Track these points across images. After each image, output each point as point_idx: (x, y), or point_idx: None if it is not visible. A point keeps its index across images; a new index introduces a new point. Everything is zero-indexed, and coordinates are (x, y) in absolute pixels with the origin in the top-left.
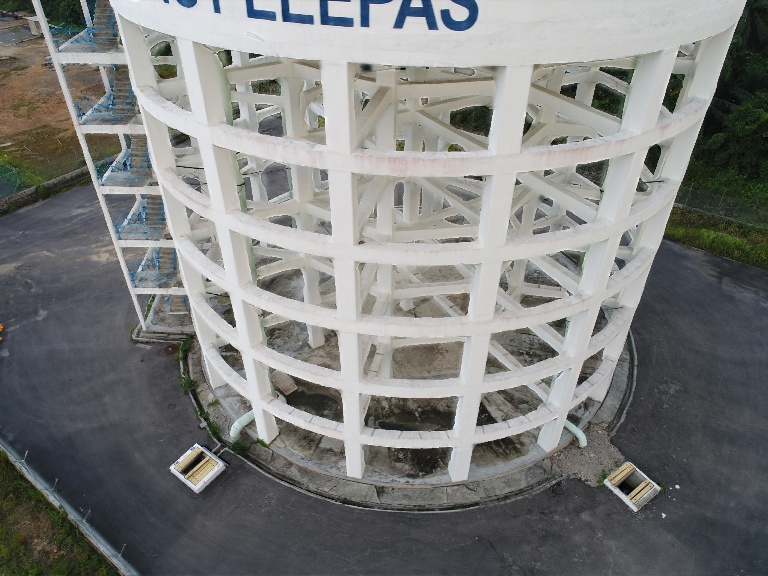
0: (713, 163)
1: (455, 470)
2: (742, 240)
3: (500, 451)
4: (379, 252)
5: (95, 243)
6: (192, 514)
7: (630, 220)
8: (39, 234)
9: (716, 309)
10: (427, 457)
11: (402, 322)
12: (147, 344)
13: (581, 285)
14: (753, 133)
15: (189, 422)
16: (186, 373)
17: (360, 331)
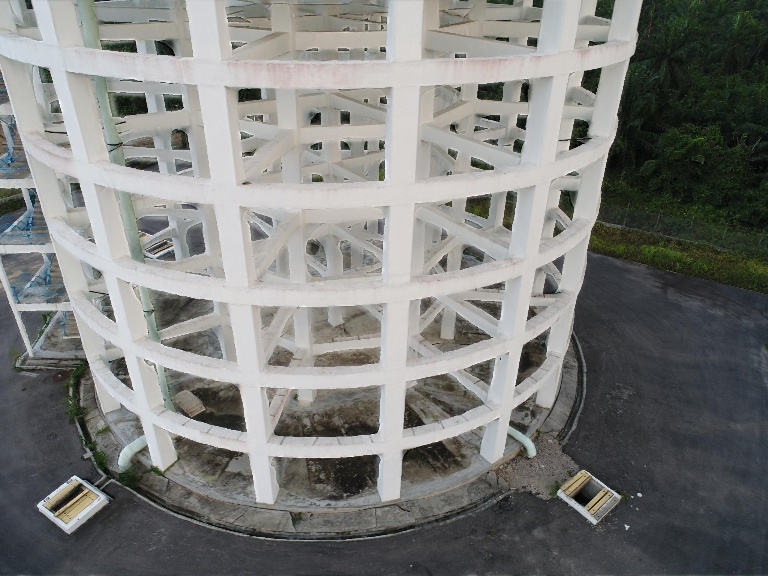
0: (647, 189)
1: (384, 486)
2: (682, 254)
3: (438, 465)
4: (267, 192)
5: None
6: (59, 559)
7: (557, 166)
8: None
9: (663, 317)
10: (353, 476)
11: (303, 288)
12: (33, 372)
13: (511, 249)
14: (682, 158)
15: (71, 453)
16: (76, 401)
17: (254, 302)
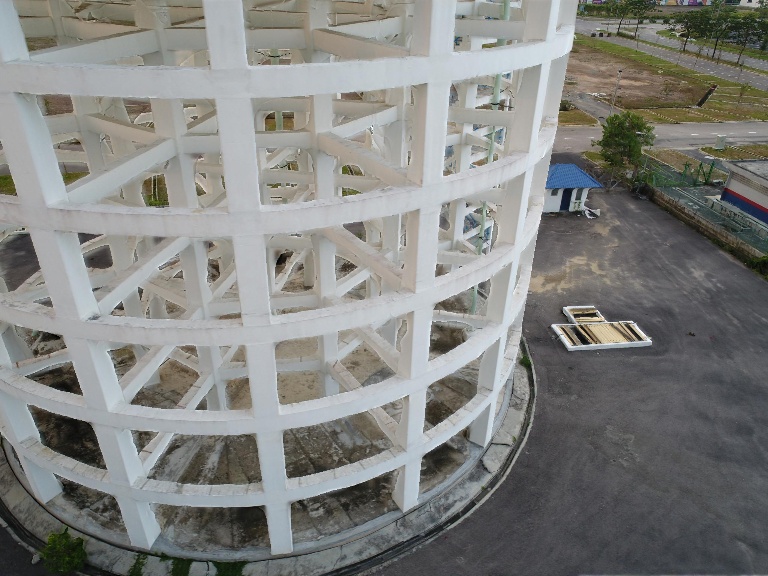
0: None
1: None
2: None
3: None
4: None
5: (611, 263)
6: None
7: None
8: (656, 249)
9: None
10: None
11: None
12: None
13: None
14: None
15: None
16: None
17: None
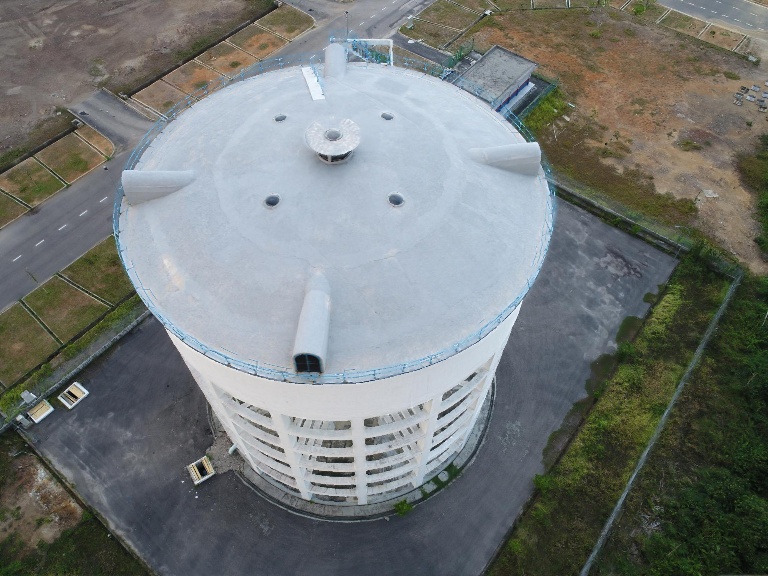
0: None
1: None
2: None
3: None
4: None
5: None
6: None
7: None
8: None
9: None
10: None
11: None
12: None
13: None
14: None
15: None
16: None
17: None
